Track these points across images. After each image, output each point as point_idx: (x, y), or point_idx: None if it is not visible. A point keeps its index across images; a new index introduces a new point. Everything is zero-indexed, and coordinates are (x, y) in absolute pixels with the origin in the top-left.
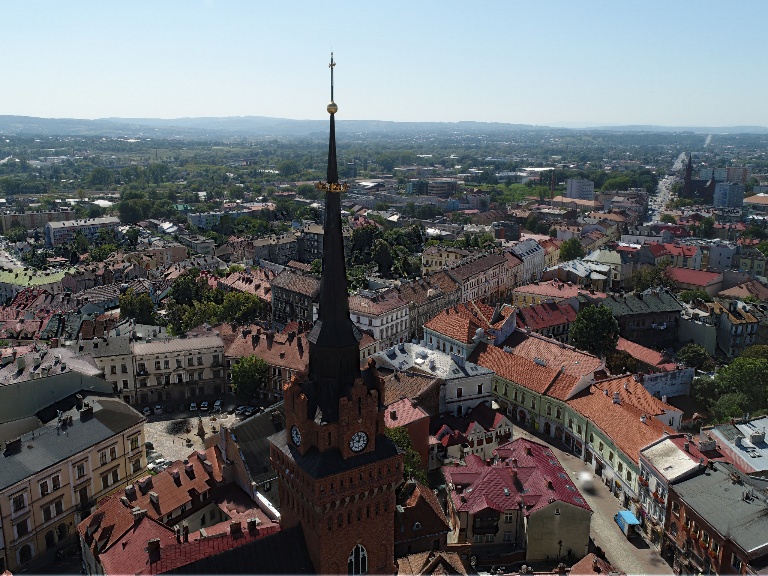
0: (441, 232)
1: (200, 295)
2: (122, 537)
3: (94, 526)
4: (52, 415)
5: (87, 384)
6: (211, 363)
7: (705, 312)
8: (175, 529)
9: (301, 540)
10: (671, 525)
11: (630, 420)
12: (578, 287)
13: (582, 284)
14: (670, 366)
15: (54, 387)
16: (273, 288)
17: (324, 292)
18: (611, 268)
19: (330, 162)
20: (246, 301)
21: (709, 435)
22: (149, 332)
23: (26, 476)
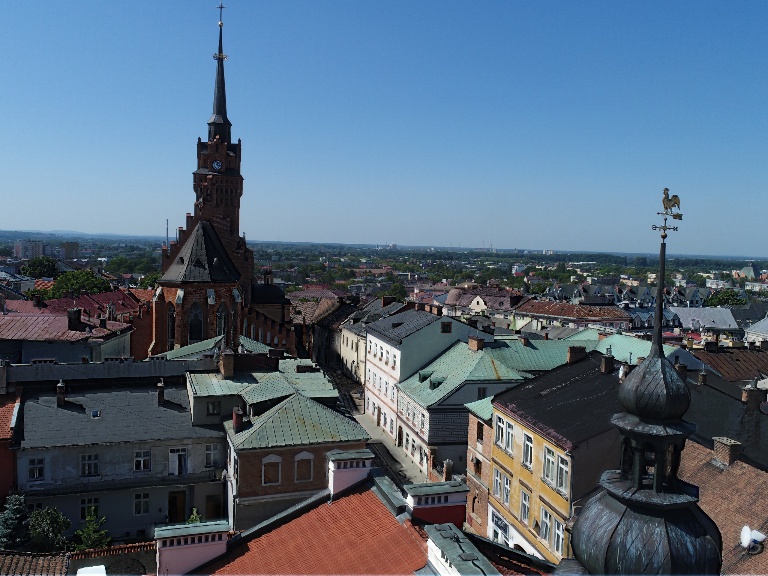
0: None
1: None
2: None
3: None
4: None
5: None
6: None
7: None
8: None
9: None
10: None
11: (143, 291)
12: None
13: None
14: None
15: None
16: None
17: (221, 101)
18: None
19: None
20: None
21: None
22: None
23: None
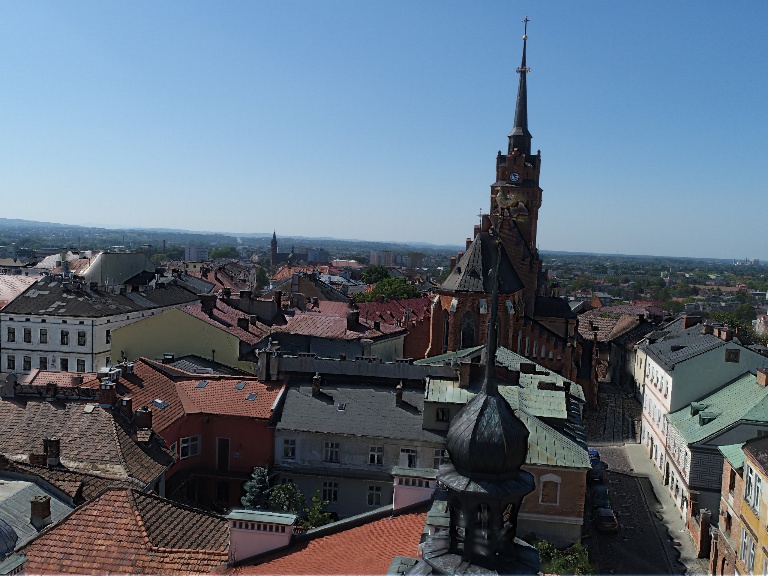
0: None
1: None
2: None
3: None
4: (144, 281)
5: (147, 266)
6: None
7: (415, 282)
8: None
9: (517, 227)
10: None
11: None
12: None
13: None
14: None
15: (133, 263)
16: None
17: (522, 114)
18: None
19: None
20: None
21: None
22: None
23: None
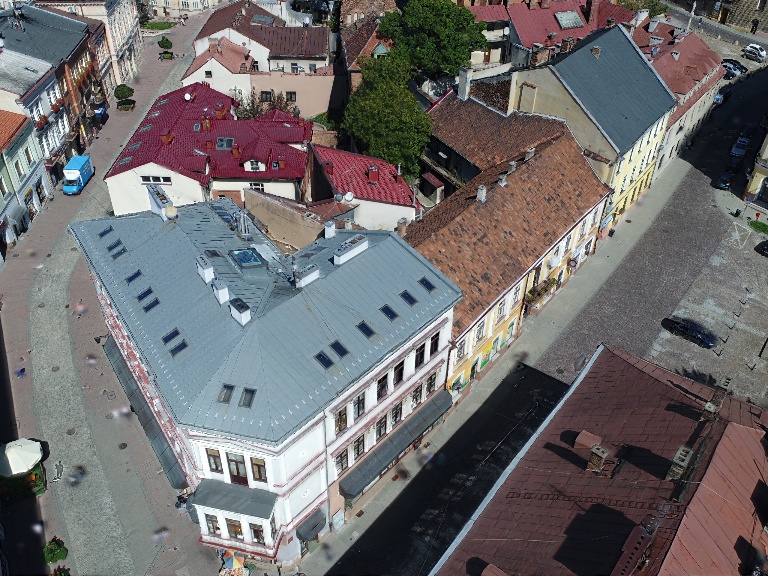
0: None
1: None
2: None
3: None
4: None
5: None
6: None
7: None
8: None
9: None
10: None
11: None
12: None
13: None
14: None
15: None
16: None
17: None
18: None
19: None
20: None
21: None
22: None
23: None
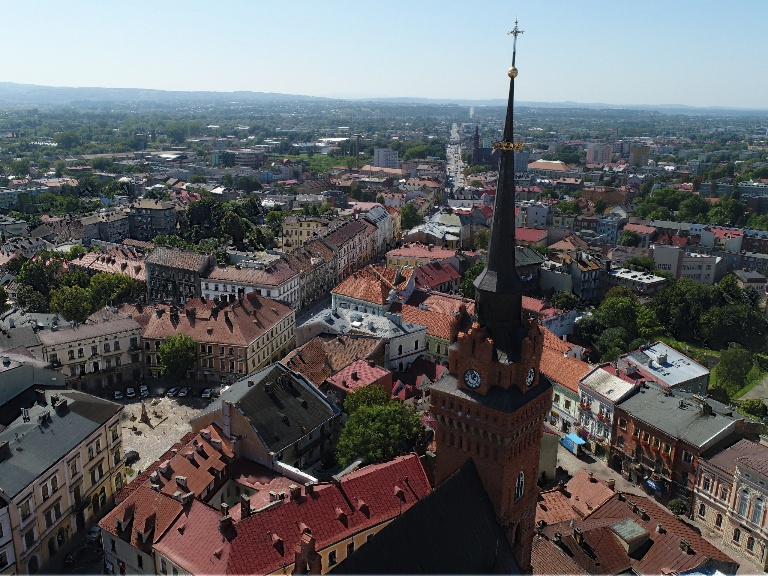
0: (275, 203)
1: (55, 280)
2: (174, 523)
3: (128, 520)
4: (11, 415)
5: (39, 378)
6: (129, 347)
7: (558, 263)
8: (224, 507)
9: (475, 475)
10: (618, 439)
11: (556, 357)
12: (443, 248)
13: (442, 245)
14: (551, 311)
15: (5, 385)
16: (148, 266)
17: (499, 244)
18: (460, 229)
19: (509, 122)
20: (119, 282)
21: (628, 361)
22: (46, 320)
23: (31, 480)
